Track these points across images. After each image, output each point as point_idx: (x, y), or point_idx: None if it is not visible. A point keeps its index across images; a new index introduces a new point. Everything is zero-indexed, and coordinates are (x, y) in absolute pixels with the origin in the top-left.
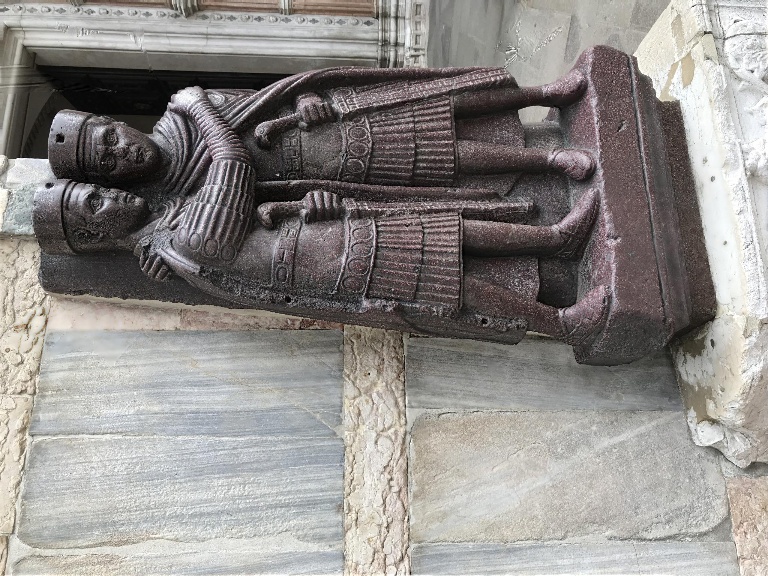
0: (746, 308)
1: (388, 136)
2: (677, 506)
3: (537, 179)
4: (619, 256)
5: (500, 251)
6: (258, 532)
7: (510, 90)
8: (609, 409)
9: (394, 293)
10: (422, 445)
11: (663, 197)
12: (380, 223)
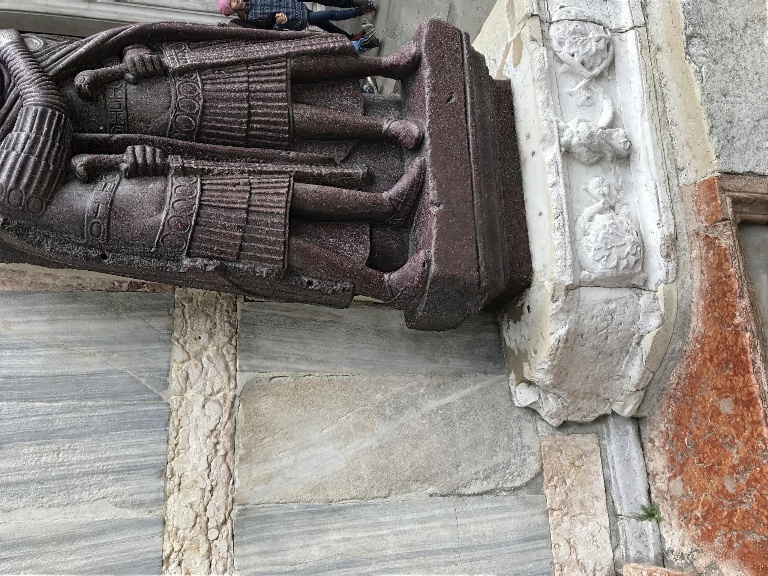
0: (554, 275)
1: (220, 94)
2: (495, 463)
3: (374, 147)
4: (440, 222)
5: (331, 215)
6: (72, 500)
7: (349, 57)
8: (437, 373)
9: (217, 252)
10: (251, 409)
11: (488, 169)
12: (206, 181)
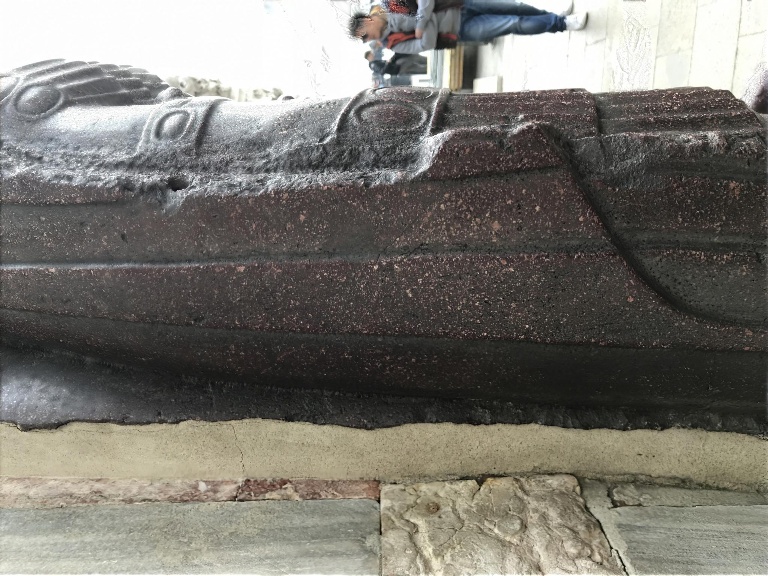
0: None
1: None
2: None
3: None
4: None
5: None
6: None
7: None
8: None
9: None
10: None
11: None
12: None
